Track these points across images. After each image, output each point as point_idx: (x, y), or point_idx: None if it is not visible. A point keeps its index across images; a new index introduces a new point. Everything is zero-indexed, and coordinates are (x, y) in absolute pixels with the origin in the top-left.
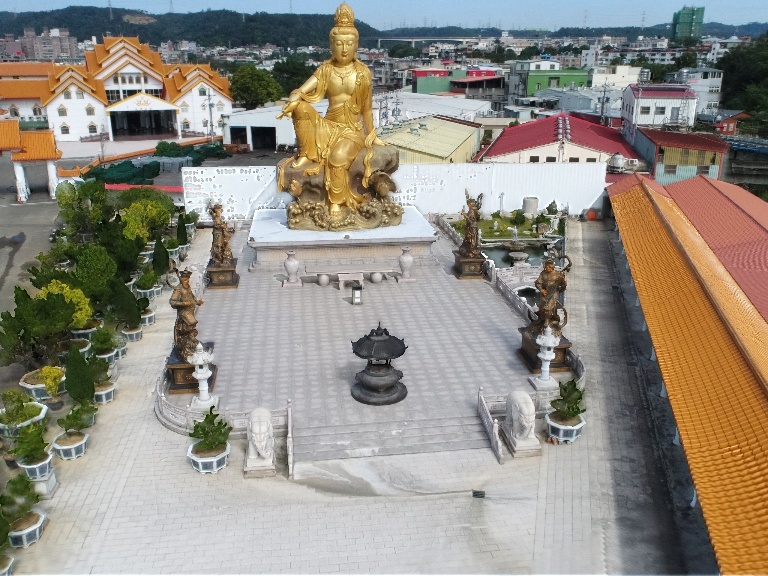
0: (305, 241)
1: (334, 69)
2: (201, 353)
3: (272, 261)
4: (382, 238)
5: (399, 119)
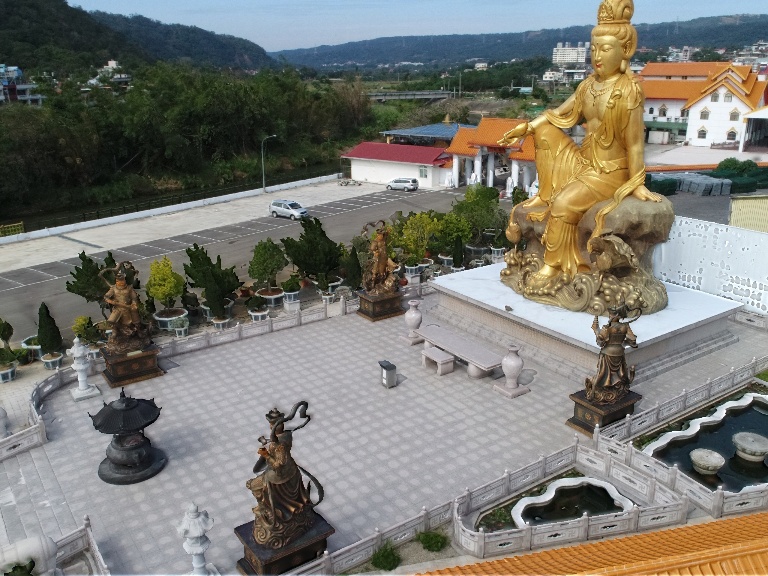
0: (469, 297)
1: (593, 84)
2: (76, 346)
3: (448, 309)
4: (542, 325)
5: None
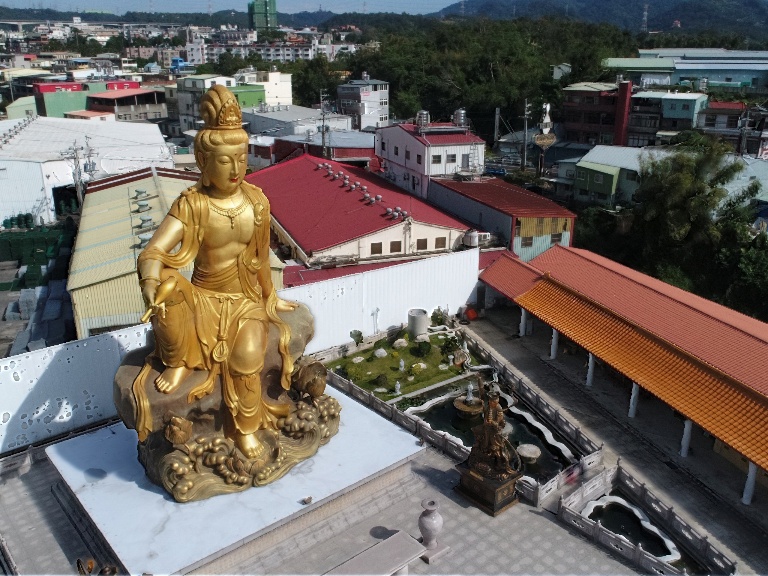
0: (245, 538)
1: (212, 203)
2: None
3: None
4: (358, 481)
5: (95, 175)
